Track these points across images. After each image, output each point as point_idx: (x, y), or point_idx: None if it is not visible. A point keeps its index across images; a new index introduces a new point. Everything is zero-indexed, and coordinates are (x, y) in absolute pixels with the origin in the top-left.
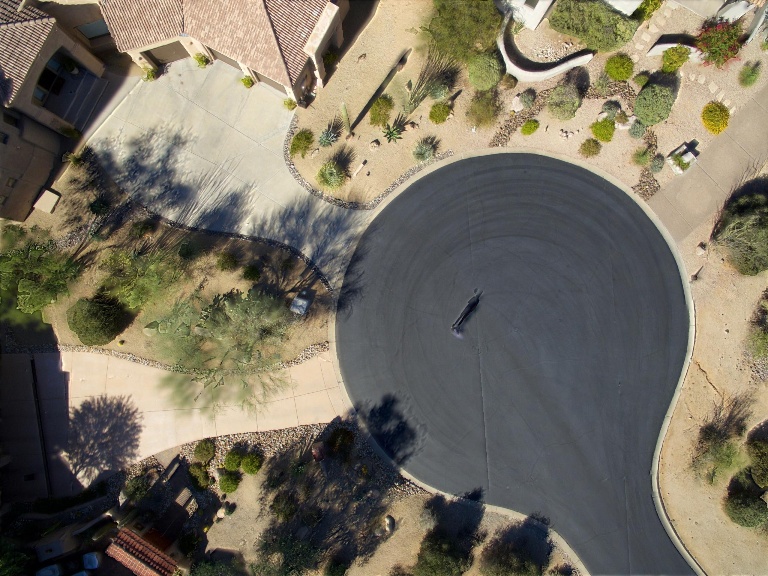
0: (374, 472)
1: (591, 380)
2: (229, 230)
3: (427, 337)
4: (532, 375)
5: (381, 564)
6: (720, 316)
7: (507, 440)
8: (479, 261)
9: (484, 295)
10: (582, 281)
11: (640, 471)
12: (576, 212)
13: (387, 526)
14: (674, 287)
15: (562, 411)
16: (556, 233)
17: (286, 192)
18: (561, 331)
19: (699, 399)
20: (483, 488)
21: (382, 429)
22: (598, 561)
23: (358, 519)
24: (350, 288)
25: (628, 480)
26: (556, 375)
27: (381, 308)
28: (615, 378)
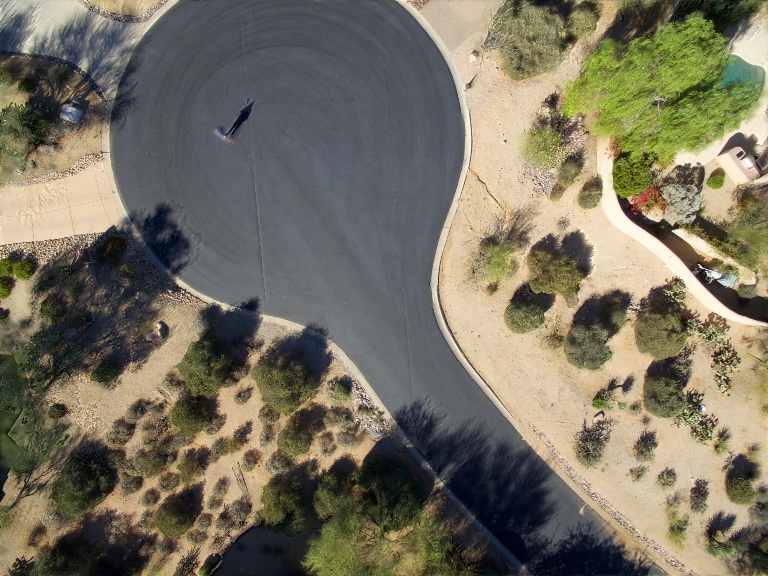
0: (144, 276)
1: (366, 189)
2: (12, 49)
3: (200, 147)
4: (306, 184)
5: (155, 371)
6: (497, 126)
7: (282, 249)
8: (252, 71)
9: (256, 104)
10: (355, 90)
11: (419, 282)
12: (348, 22)
13: (158, 331)
14: (448, 95)
15: (337, 220)
16: (328, 43)
17: (66, 11)
18: (334, 140)
19: (479, 211)
20: (259, 298)
21: (157, 238)
22: (378, 373)
23: (128, 323)
24: (124, 99)
25: (407, 291)
26: (330, 184)
27: (154, 118)
28: (390, 187)
